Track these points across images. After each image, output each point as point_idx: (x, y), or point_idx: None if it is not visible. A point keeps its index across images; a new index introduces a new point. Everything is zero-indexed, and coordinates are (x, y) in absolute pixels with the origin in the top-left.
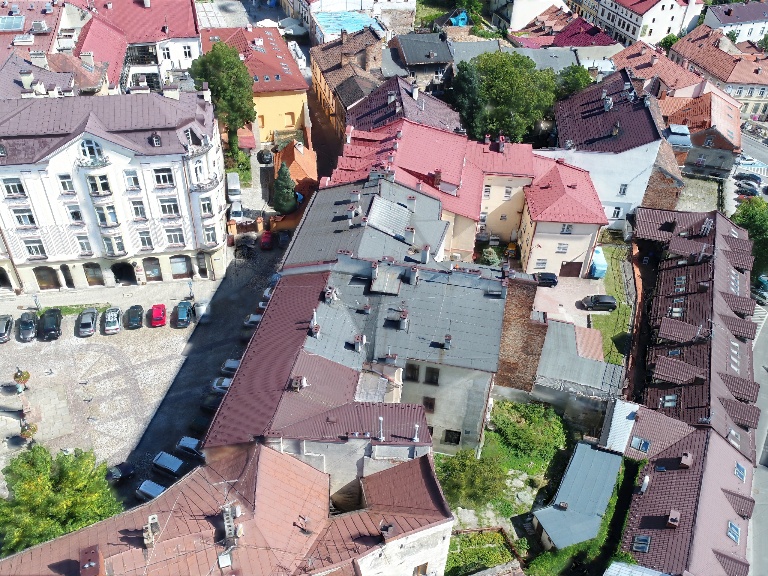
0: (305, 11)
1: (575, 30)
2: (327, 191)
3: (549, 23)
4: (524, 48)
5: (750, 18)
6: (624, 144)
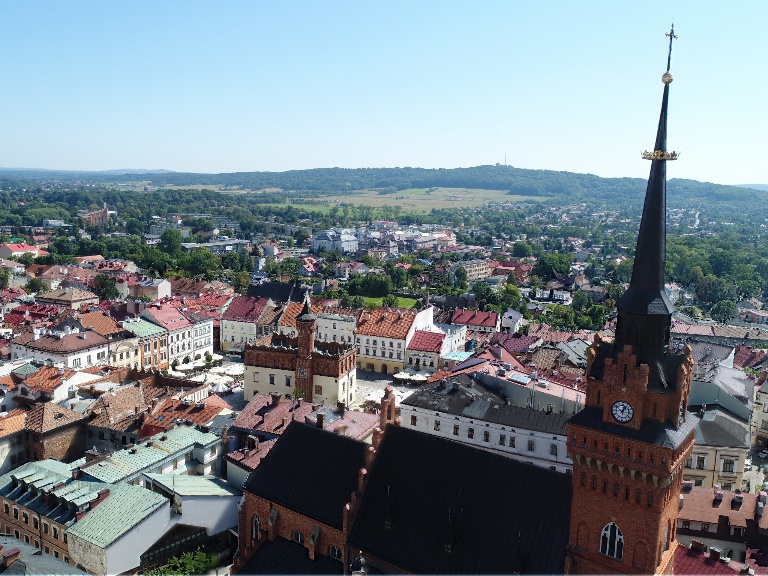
0: (425, 360)
1: (503, 339)
2: (765, 389)
3: (478, 340)
4: (569, 343)
5: (517, 318)
6: (722, 355)
